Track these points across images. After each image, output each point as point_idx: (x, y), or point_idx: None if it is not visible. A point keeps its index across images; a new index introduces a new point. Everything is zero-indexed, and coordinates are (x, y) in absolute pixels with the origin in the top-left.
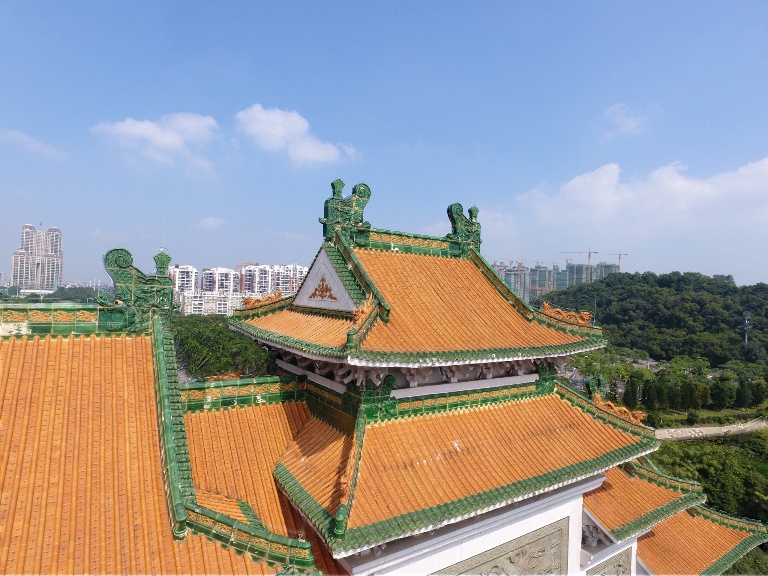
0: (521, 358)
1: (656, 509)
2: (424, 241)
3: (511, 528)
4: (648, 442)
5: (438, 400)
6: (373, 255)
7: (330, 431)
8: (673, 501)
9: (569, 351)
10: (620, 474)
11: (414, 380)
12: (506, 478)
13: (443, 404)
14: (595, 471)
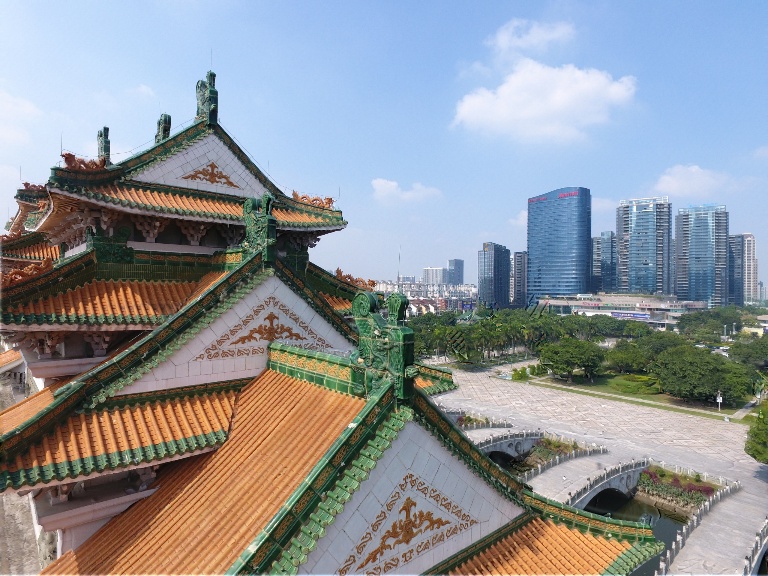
0: None
1: None
2: None
3: None
4: None
5: None
6: None
7: None
8: None
9: None
10: None
11: None
12: None
13: None
14: None
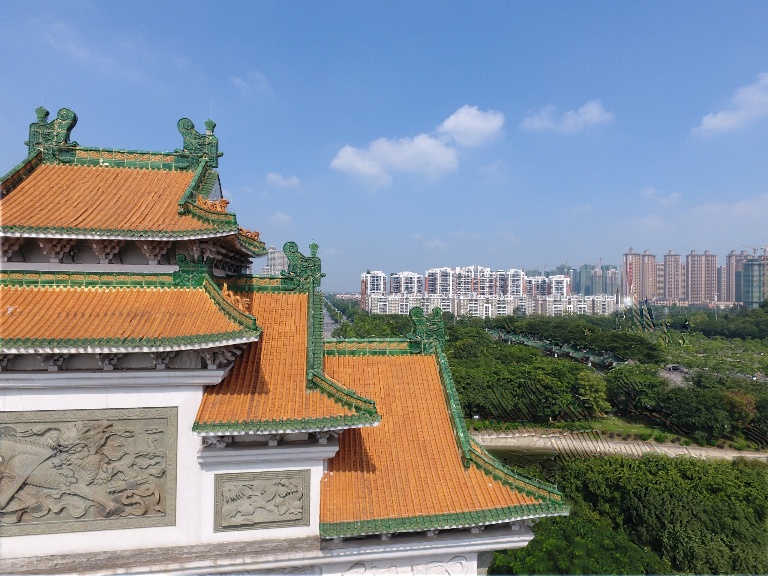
0: (99, 237)
1: (294, 419)
2: (142, 156)
3: (78, 397)
4: (244, 331)
5: (28, 276)
6: (74, 169)
7: None
8: (330, 416)
9: (178, 236)
10: (302, 386)
11: (2, 256)
12: (19, 335)
13: (34, 280)
14: (144, 348)
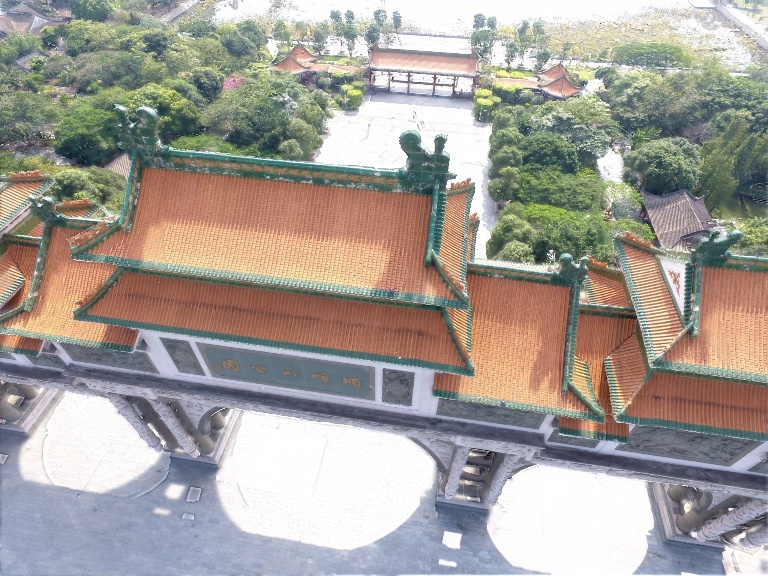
0: None
1: None
2: None
3: None
4: None
5: None
6: None
7: (38, 228)
8: None
9: None
10: None
11: None
12: None
13: None
14: None
